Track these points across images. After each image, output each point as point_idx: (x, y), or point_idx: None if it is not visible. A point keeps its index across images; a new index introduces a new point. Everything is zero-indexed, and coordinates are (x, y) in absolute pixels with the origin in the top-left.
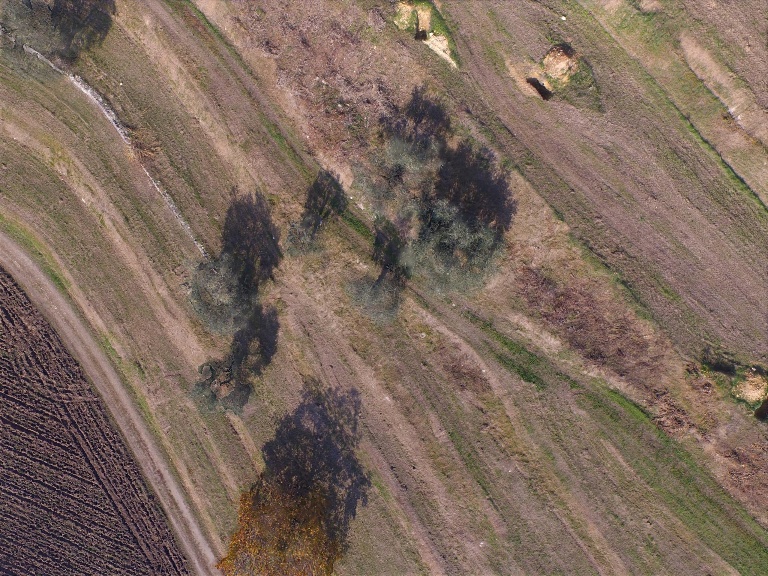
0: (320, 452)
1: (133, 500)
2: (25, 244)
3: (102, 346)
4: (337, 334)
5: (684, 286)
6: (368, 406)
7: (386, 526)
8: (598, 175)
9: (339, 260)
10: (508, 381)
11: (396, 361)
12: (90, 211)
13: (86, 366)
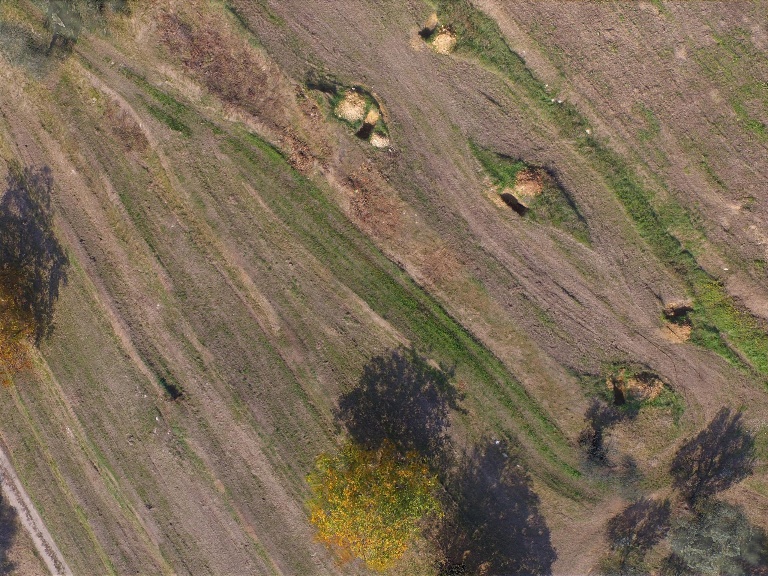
0: (26, 236)
1: None
2: None
3: None
4: (29, 112)
5: (288, 11)
6: (60, 182)
7: (85, 304)
8: None
9: (18, 32)
10: (159, 131)
11: (72, 128)
12: None
13: None
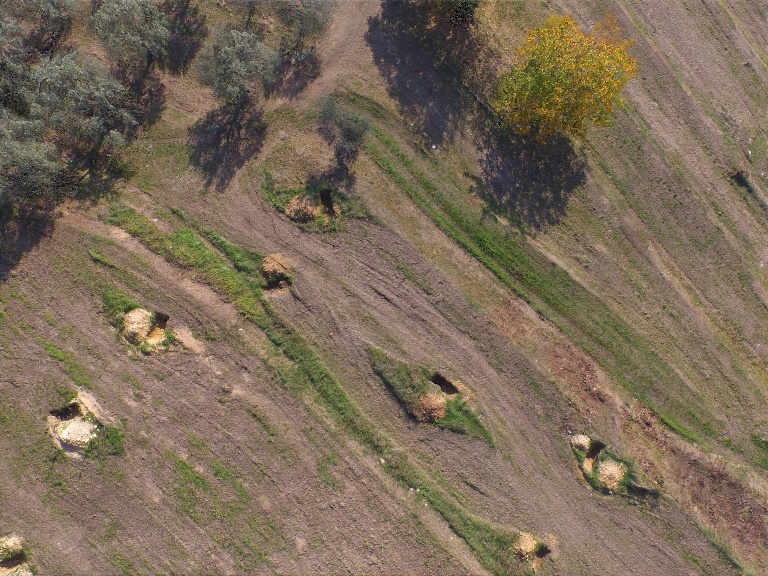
0: None
1: None
2: None
3: None
4: None
5: (680, 568)
6: None
7: None
8: None
9: None
10: None
11: None
12: None
13: None
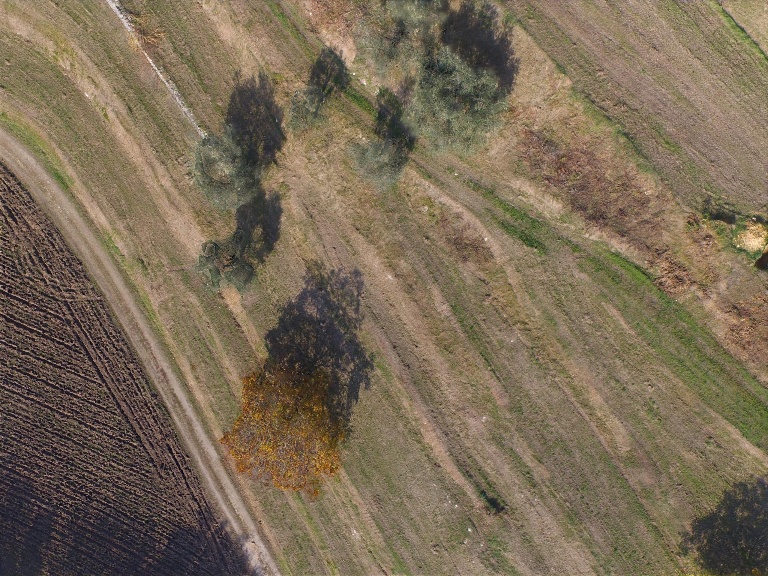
0: (323, 337)
1: (136, 398)
2: (28, 143)
3: (105, 245)
4: (340, 215)
5: (685, 137)
6: (371, 286)
7: (389, 408)
8: (600, 28)
9: (342, 136)
10: (510, 247)
11: (399, 236)
12: (93, 106)
13: (89, 265)
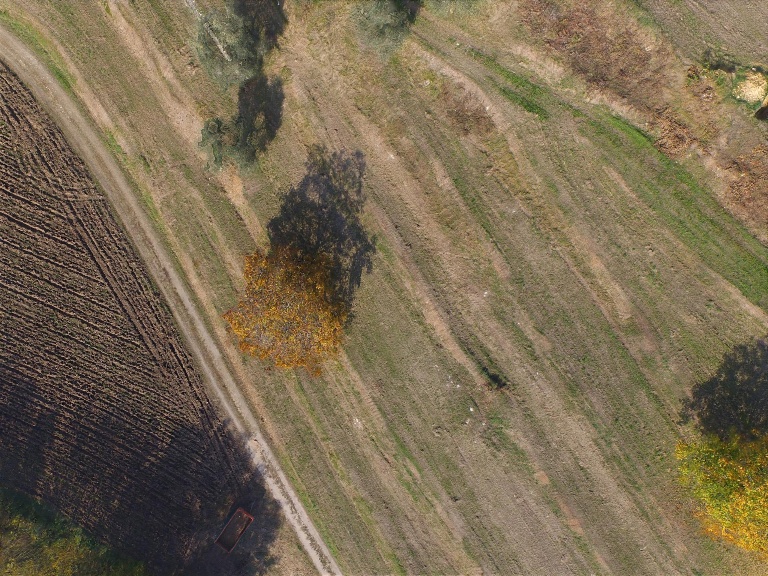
0: (325, 223)
1: (139, 297)
2: (30, 42)
3: (107, 144)
4: (342, 96)
5: None
6: (373, 167)
7: (391, 291)
8: None
9: (344, 13)
10: (512, 114)
11: (400, 111)
12: (95, 0)
13: (91, 165)
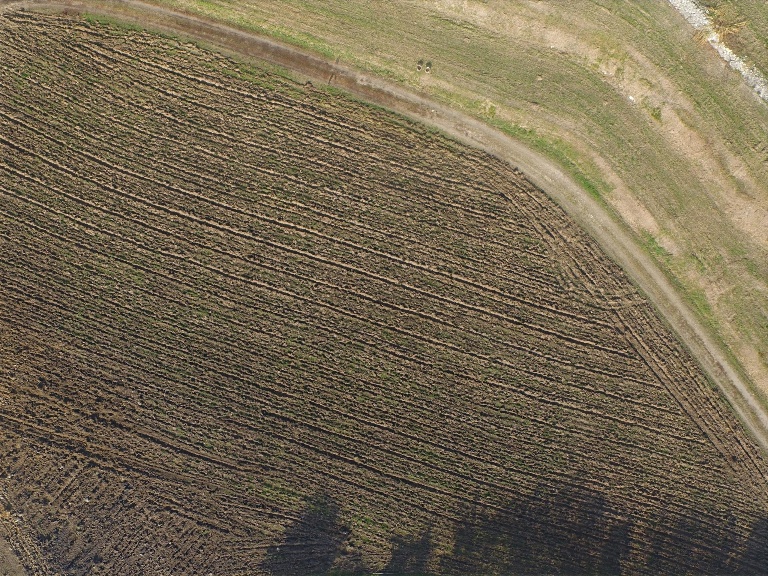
0: None
1: (697, 396)
2: (555, 157)
3: (645, 247)
4: None
5: None
6: None
7: None
8: None
9: None
10: None
11: None
12: (638, 108)
13: (629, 270)
